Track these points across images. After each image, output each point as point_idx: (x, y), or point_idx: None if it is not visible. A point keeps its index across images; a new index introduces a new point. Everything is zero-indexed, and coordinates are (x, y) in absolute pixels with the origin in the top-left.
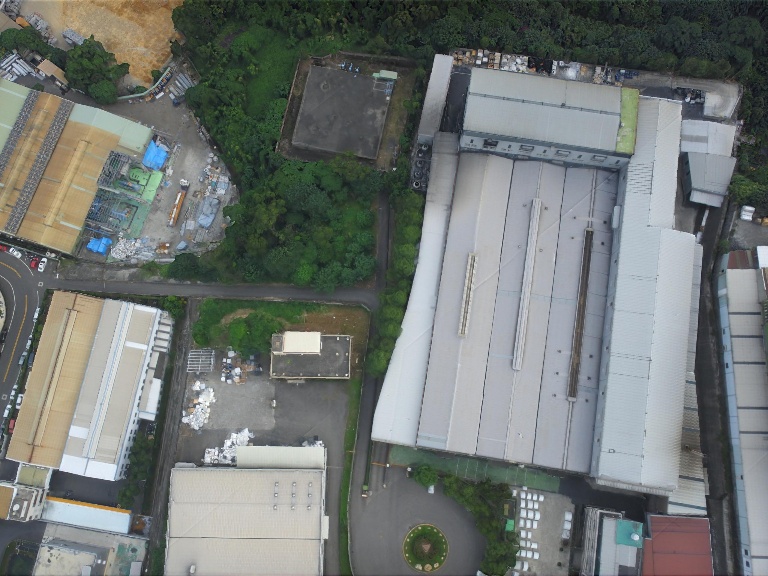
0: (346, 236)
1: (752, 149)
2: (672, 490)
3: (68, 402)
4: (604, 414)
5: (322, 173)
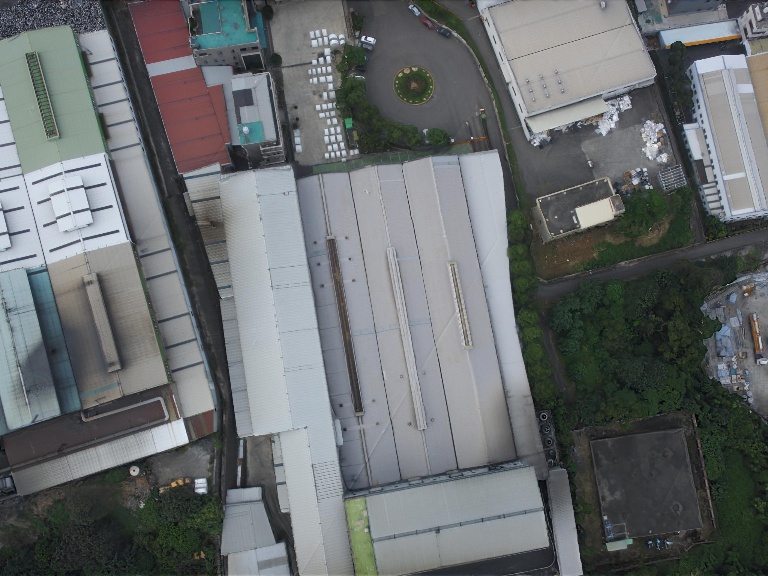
0: (588, 346)
1: None
2: None
3: (767, 111)
4: None
5: (639, 405)
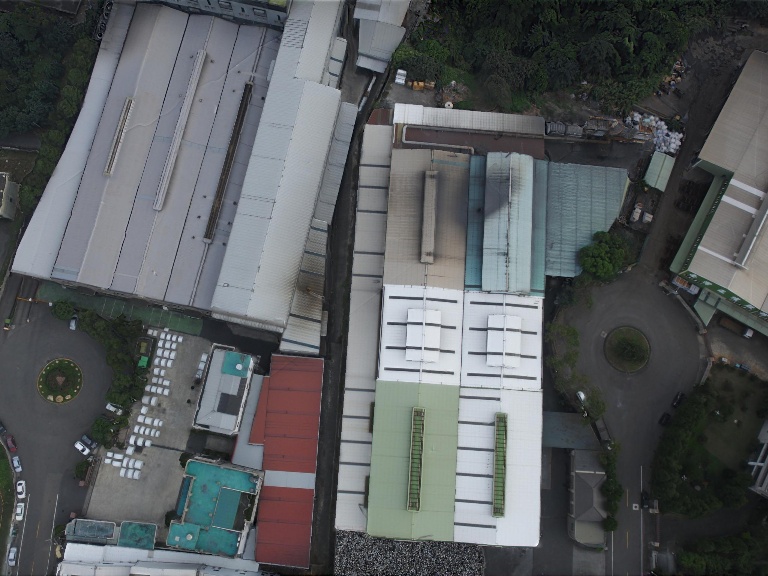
0: (32, 85)
1: (433, 26)
2: (283, 326)
3: None
4: (225, 251)
5: (16, 22)
